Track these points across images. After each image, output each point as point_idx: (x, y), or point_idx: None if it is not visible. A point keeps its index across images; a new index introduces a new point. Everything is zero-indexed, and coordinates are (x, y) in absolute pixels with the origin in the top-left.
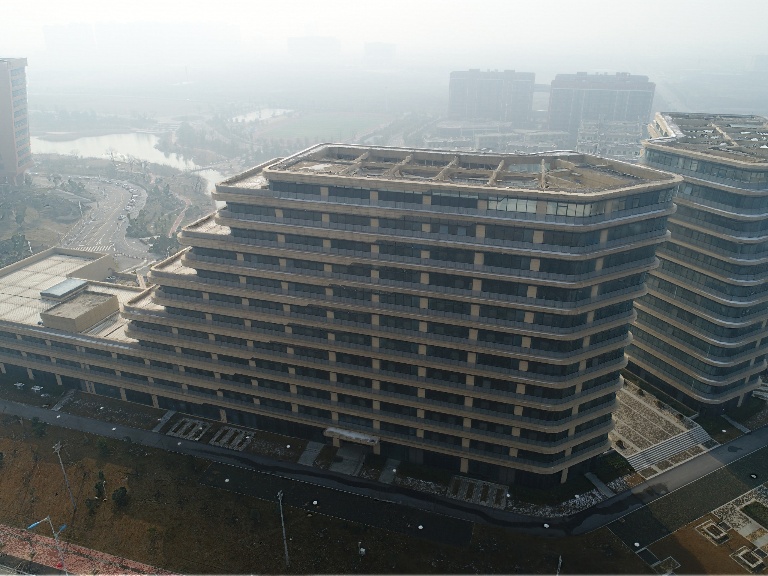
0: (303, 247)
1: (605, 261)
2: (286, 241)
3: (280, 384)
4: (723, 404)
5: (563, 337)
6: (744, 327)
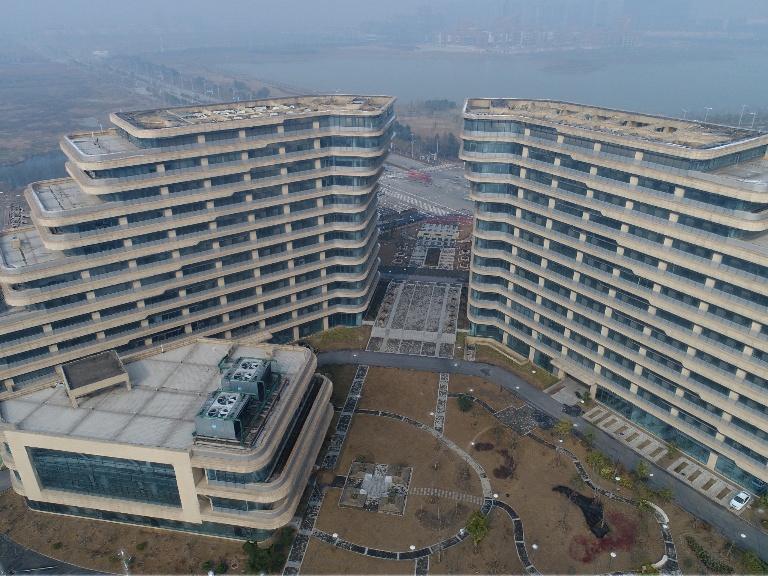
0: None
1: None
2: None
3: None
4: None
5: None
6: None
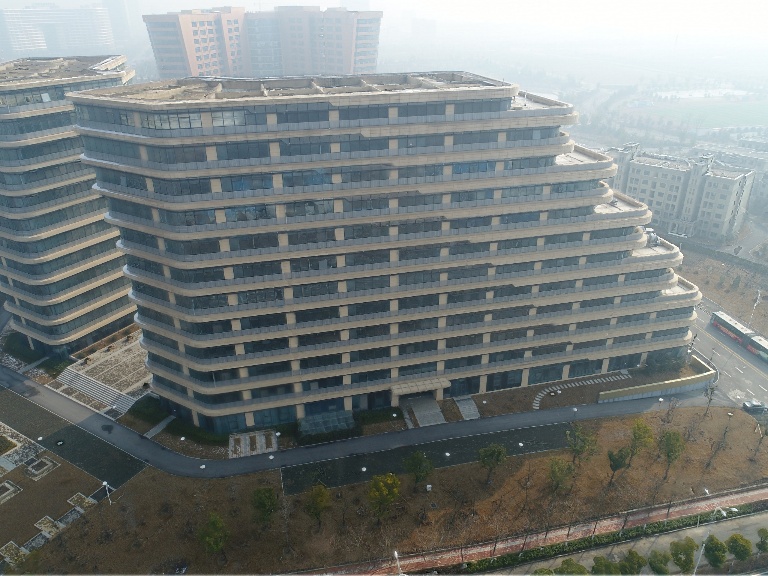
0: None
1: None
2: None
3: None
4: (171, 402)
5: None
6: (149, 309)
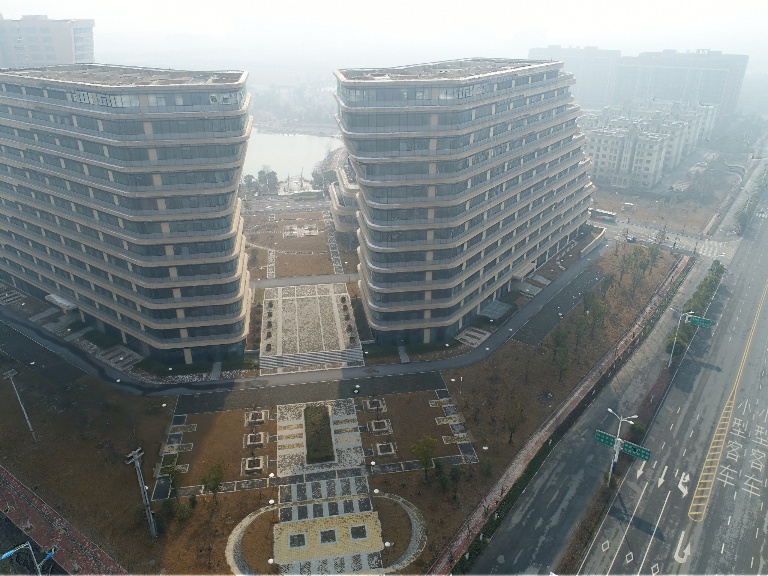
0: (7, 136)
1: (162, 153)
2: (0, 131)
3: (28, 255)
4: (399, 335)
5: (131, 218)
6: (397, 254)
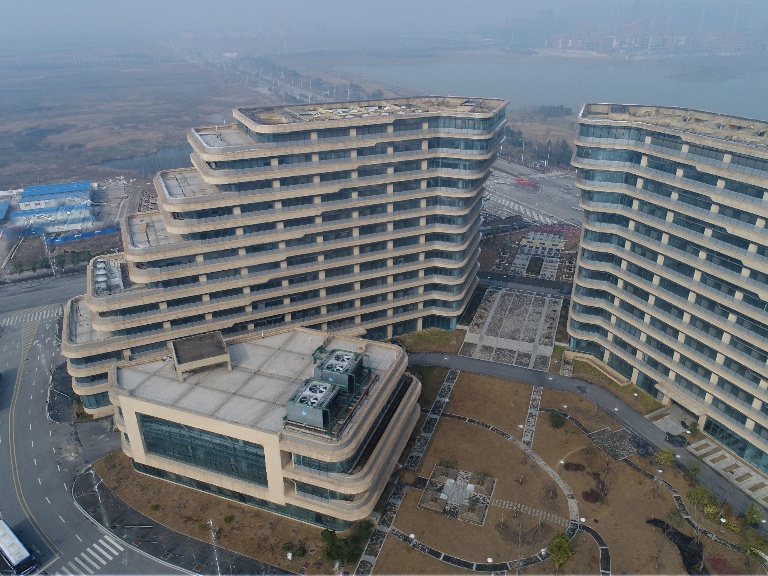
0: None
1: None
2: None
3: None
4: None
5: None
6: None
